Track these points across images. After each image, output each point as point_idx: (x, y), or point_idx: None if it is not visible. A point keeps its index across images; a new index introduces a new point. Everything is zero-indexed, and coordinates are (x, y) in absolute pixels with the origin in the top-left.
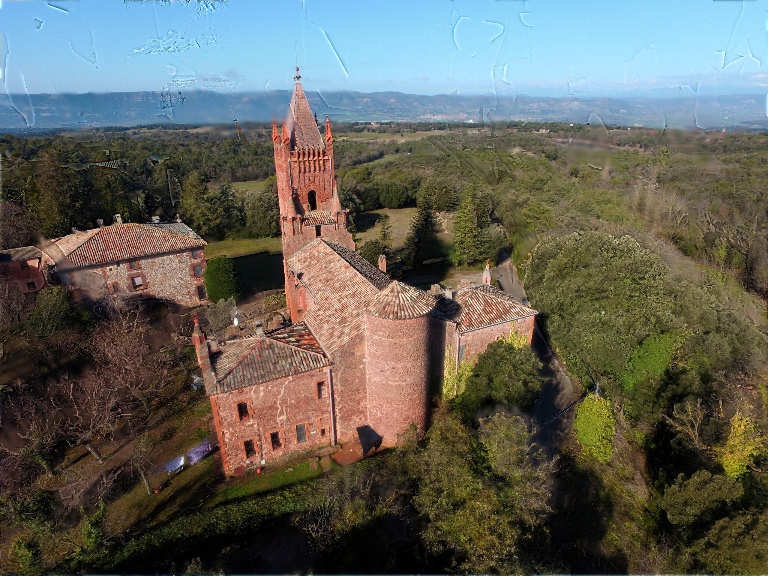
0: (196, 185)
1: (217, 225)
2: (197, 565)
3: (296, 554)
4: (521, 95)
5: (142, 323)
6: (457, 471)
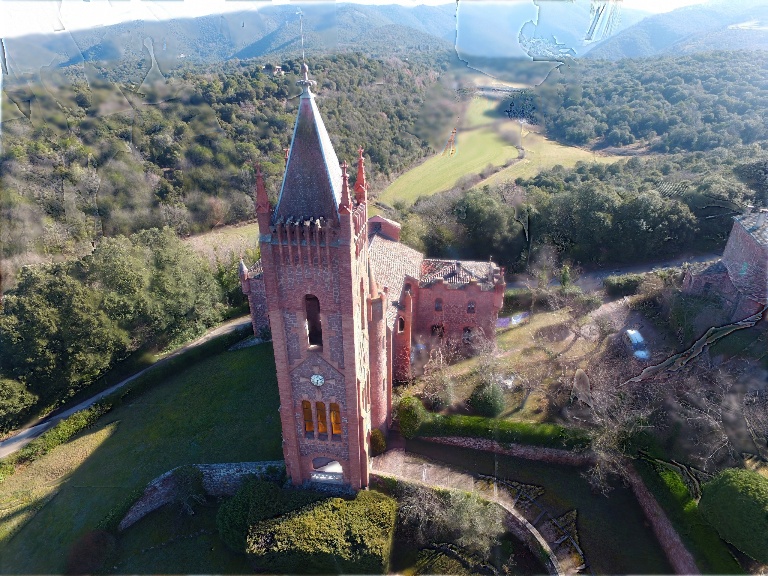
0: None
1: None
2: None
3: None
4: None
5: None
6: None
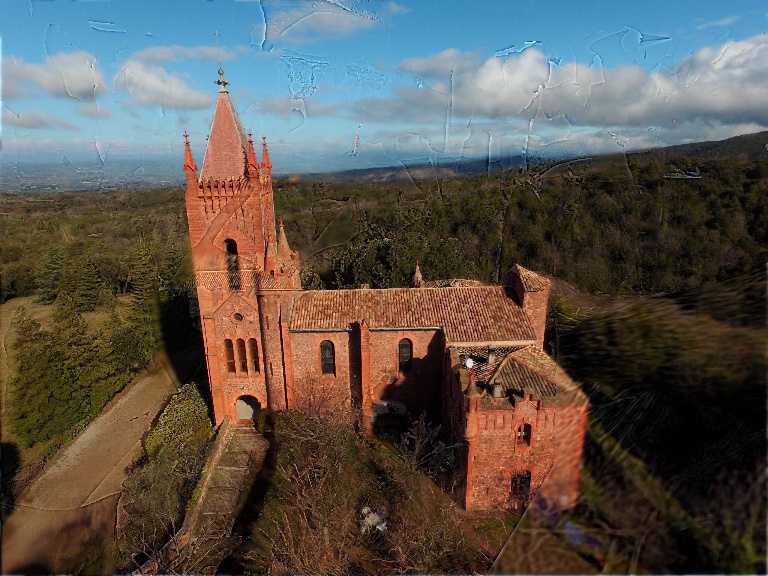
0: None
1: None
2: None
3: None
4: (91, 144)
5: None
6: None
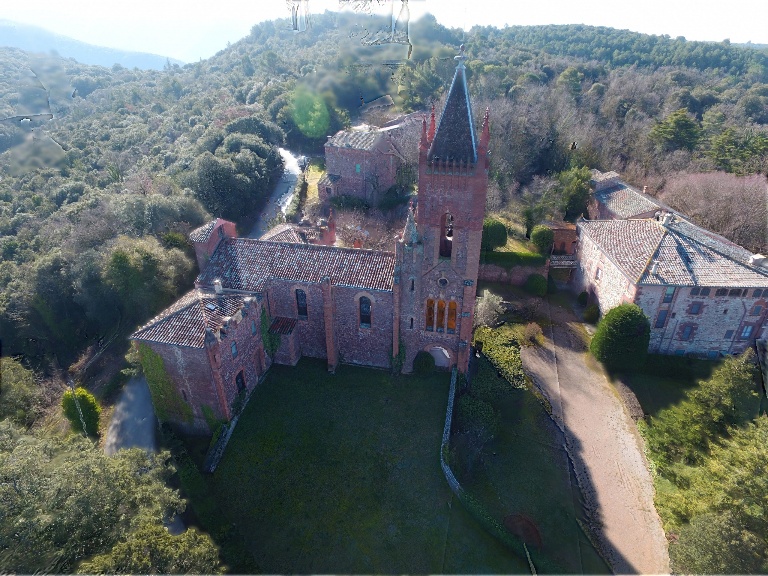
0: None
1: None
2: None
3: None
4: None
5: (579, 309)
6: None
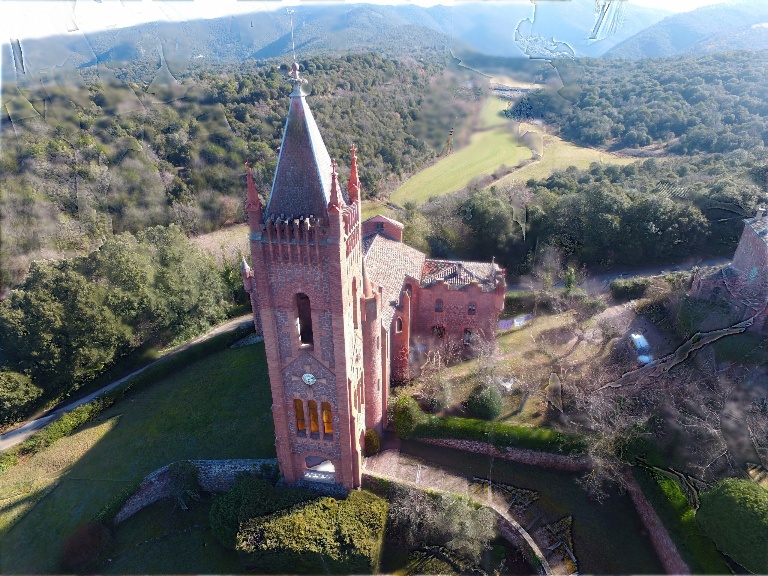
0: None
1: None
2: None
3: (471, 249)
4: None
5: None
6: None
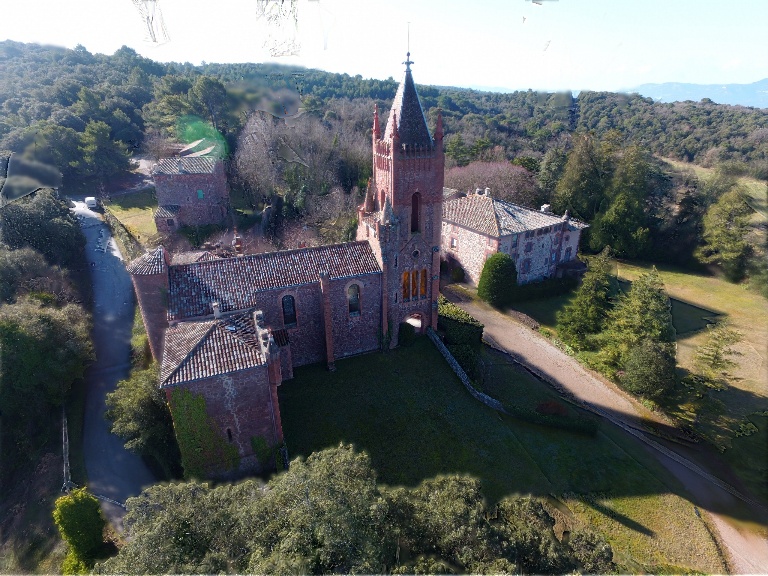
0: (732, 200)
1: (741, 262)
2: (63, 270)
3: None
4: None
5: (444, 275)
6: (5, 304)
